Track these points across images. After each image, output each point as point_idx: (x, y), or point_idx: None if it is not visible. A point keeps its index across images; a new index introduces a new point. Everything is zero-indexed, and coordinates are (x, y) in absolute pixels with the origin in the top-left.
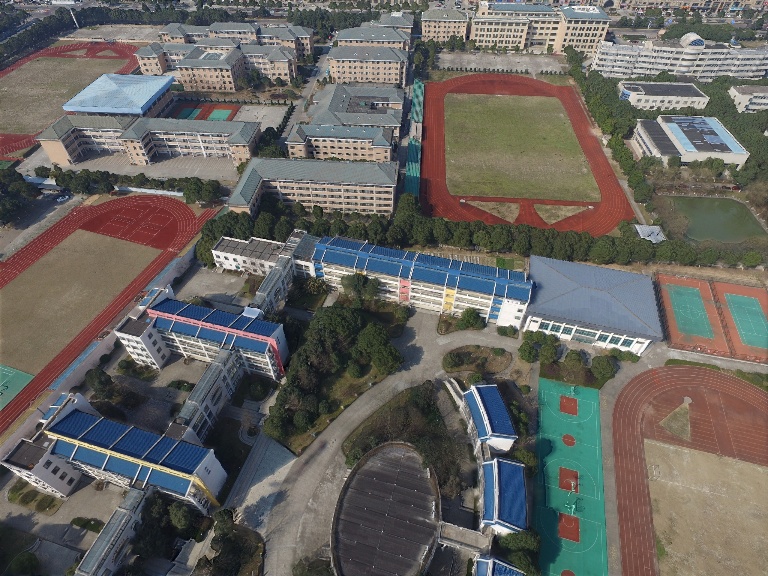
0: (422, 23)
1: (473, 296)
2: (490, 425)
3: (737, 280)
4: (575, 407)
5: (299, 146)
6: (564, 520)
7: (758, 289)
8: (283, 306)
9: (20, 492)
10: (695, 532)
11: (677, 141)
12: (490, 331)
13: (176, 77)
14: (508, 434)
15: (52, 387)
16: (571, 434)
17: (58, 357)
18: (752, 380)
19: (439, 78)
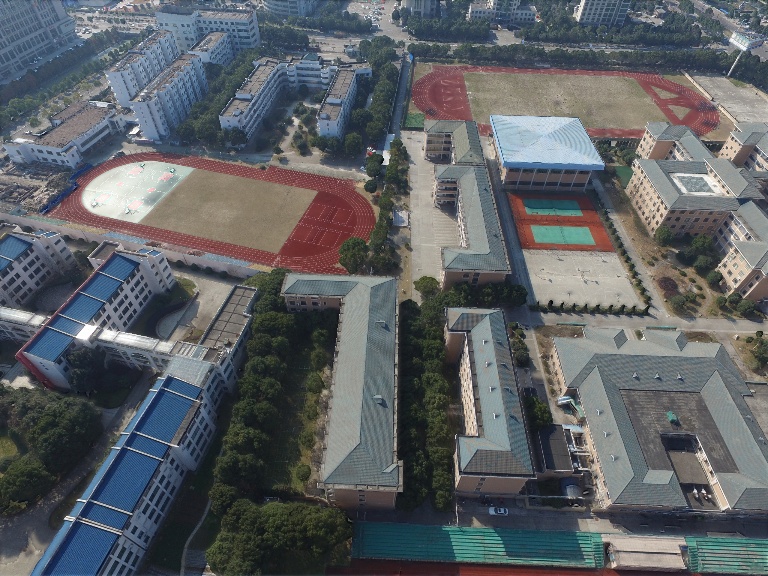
0: None
1: None
2: None
3: None
4: None
5: None
6: None
7: None
8: None
9: None
10: None
11: None
12: None
13: None
14: None
15: (110, 233)
16: None
17: (152, 228)
18: None
19: None
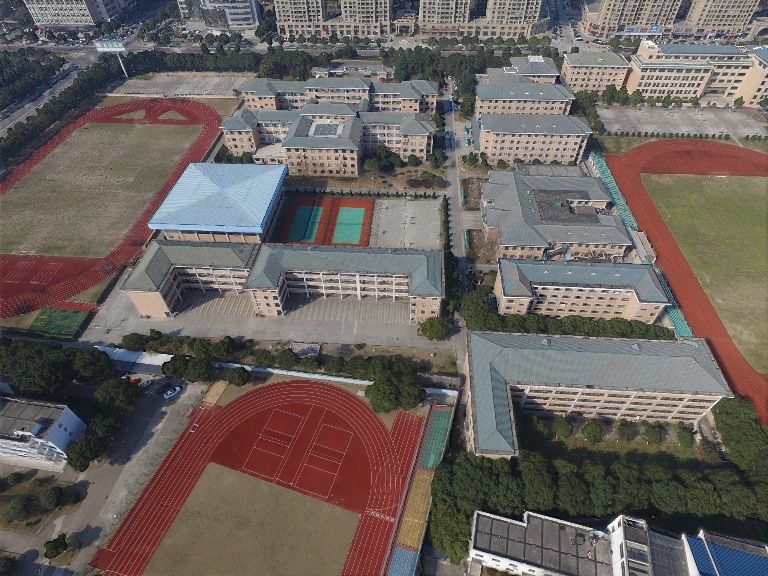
0: (568, 69)
1: None
2: None
3: None
4: None
5: (522, 300)
6: None
7: None
8: None
9: None
10: None
11: None
12: None
13: (276, 156)
14: None
15: None
16: None
17: None
18: None
19: (616, 148)
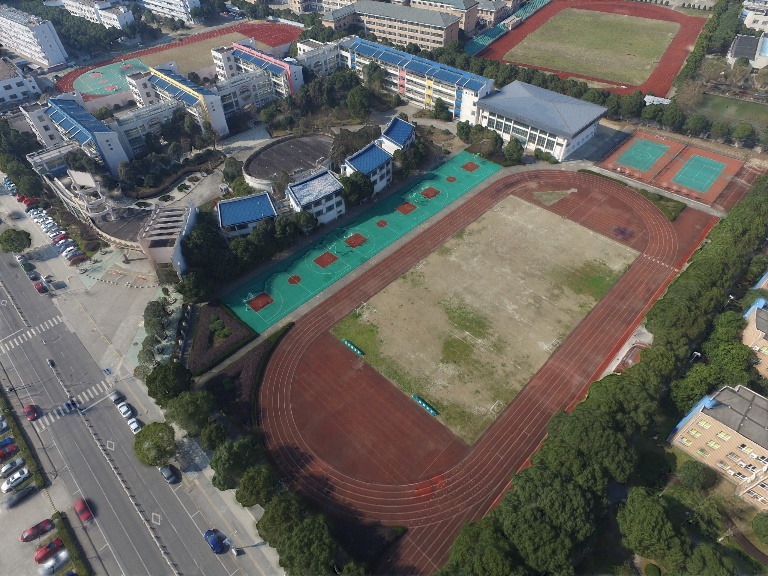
0: None
1: (444, 87)
2: (386, 132)
3: (720, 151)
4: (474, 168)
5: (399, 4)
6: (406, 205)
7: (736, 160)
8: None
9: None
10: (495, 237)
11: (759, 48)
12: (452, 124)
13: None
14: (396, 141)
15: None
16: (456, 177)
17: None
18: (649, 196)
19: None
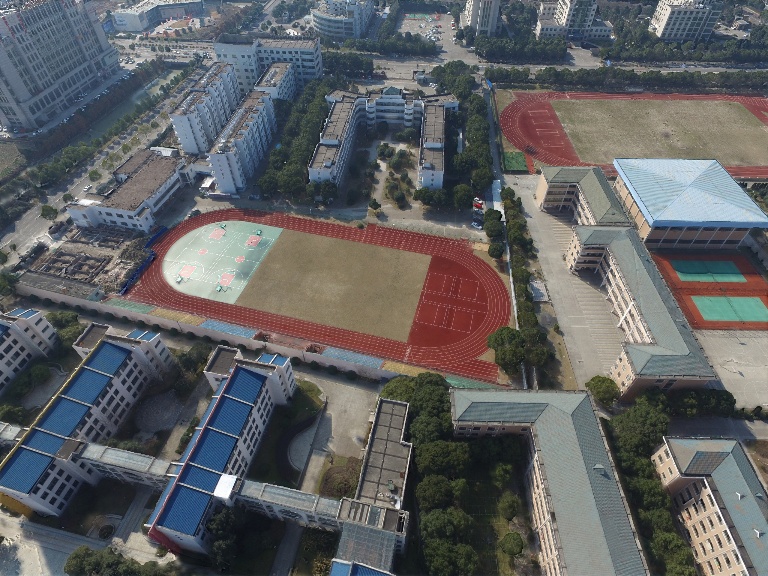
0: None
1: None
2: None
3: None
4: None
5: (674, 466)
6: None
7: None
8: (305, 525)
9: None
10: None
11: None
12: None
13: None
14: None
15: (207, 321)
16: None
17: (253, 311)
18: None
19: None
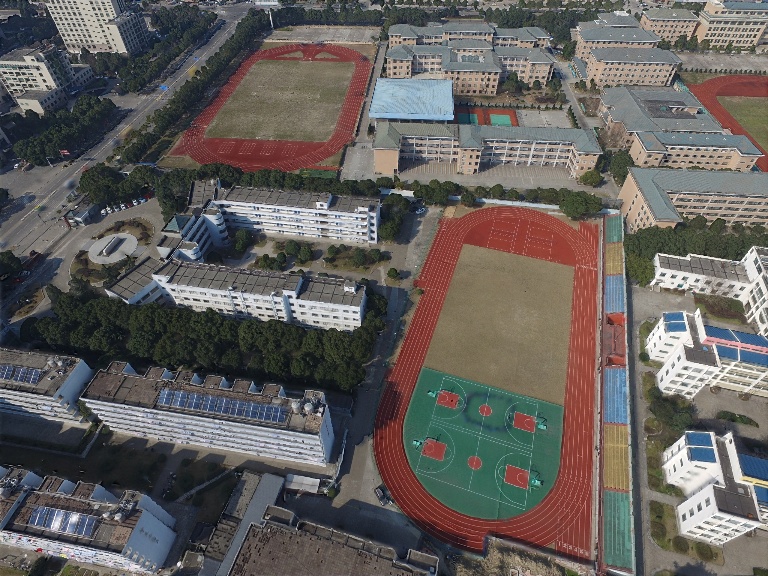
0: (648, 22)
1: None
2: None
3: None
4: None
5: (658, 155)
6: None
7: None
8: None
9: (667, 538)
10: None
11: None
12: None
13: None
14: None
15: (610, 420)
16: None
17: (569, 385)
18: None
19: (693, 80)
